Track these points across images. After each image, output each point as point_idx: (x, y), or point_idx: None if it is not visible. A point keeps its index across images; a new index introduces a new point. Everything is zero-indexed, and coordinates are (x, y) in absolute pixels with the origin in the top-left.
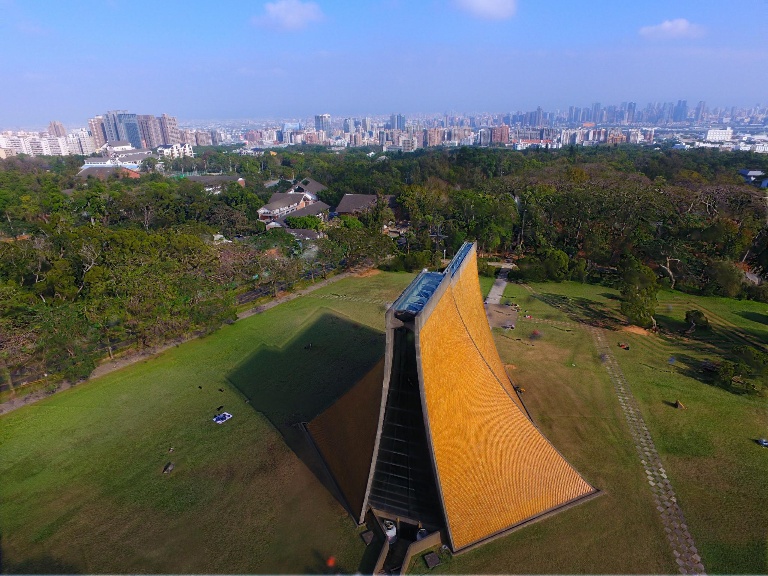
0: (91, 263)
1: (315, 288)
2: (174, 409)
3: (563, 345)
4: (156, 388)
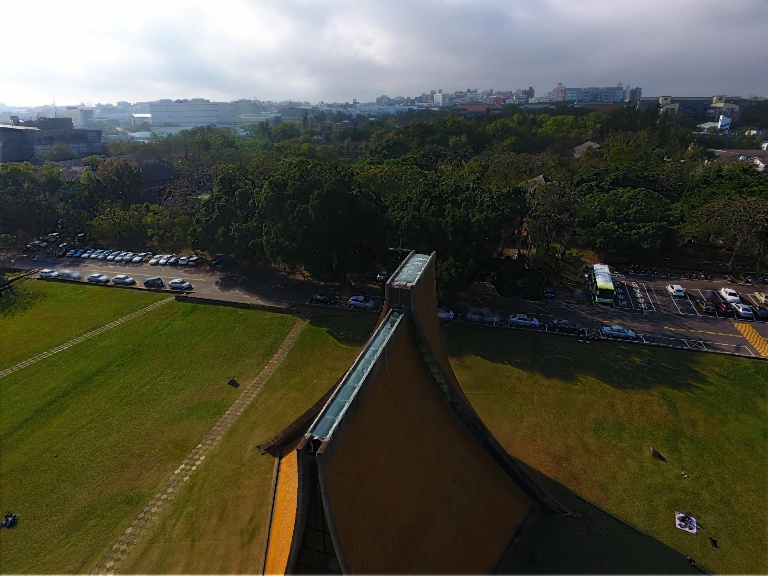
0: None
1: None
2: None
3: None
4: None
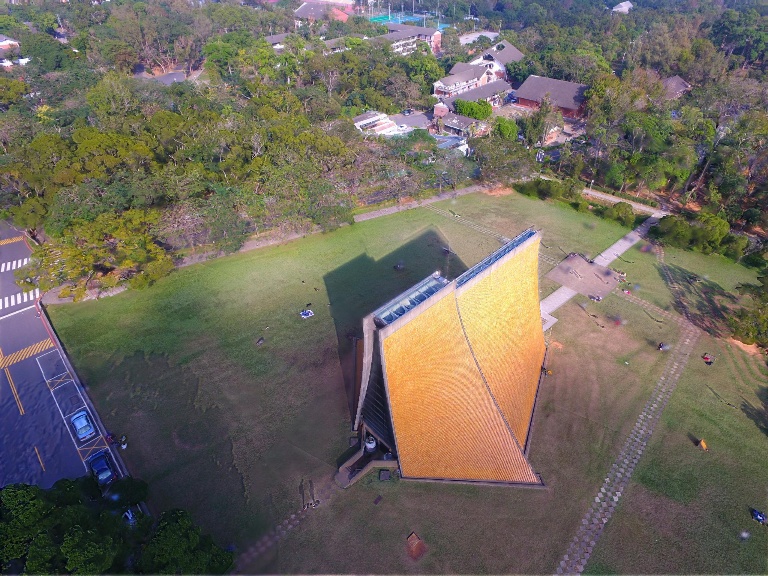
0: (257, 151)
1: (439, 199)
2: (280, 295)
3: (637, 336)
4: (276, 273)
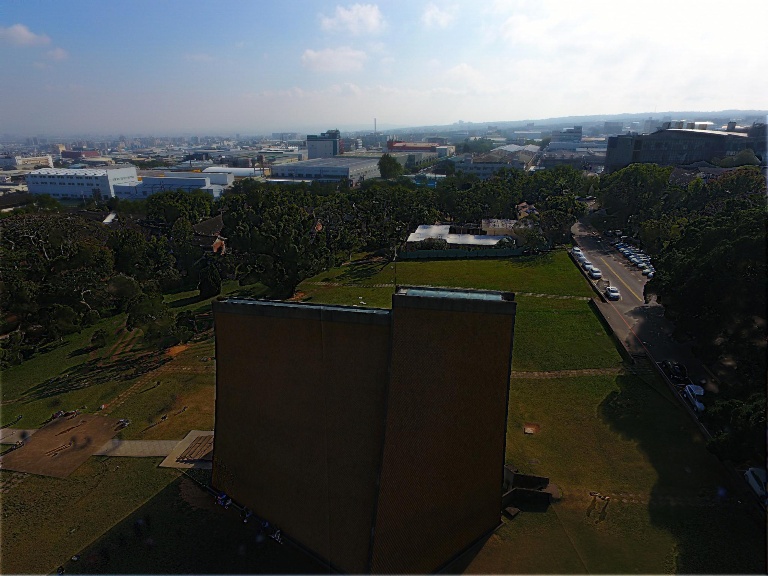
0: None
1: None
2: None
3: (192, 389)
4: None
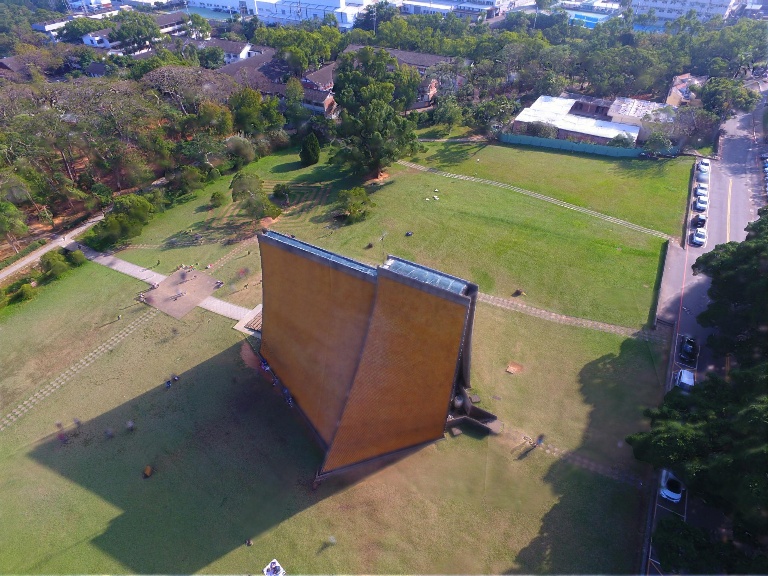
0: None
1: None
2: None
3: None
4: None
